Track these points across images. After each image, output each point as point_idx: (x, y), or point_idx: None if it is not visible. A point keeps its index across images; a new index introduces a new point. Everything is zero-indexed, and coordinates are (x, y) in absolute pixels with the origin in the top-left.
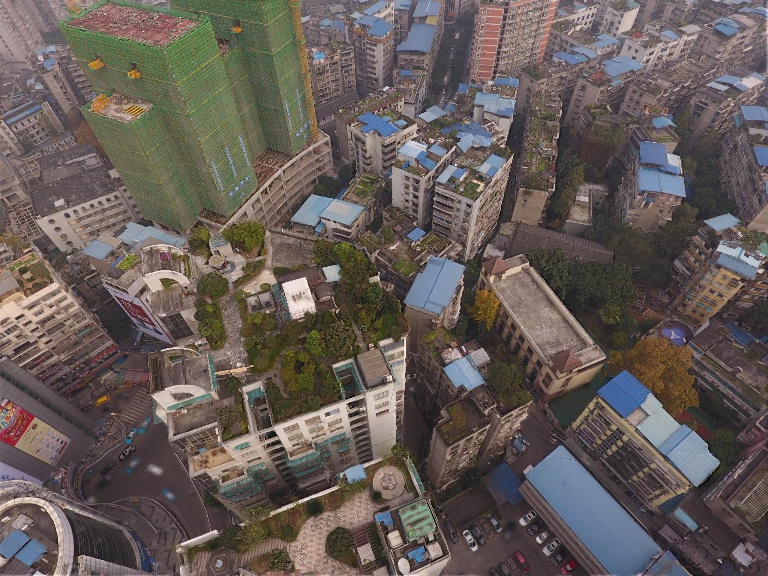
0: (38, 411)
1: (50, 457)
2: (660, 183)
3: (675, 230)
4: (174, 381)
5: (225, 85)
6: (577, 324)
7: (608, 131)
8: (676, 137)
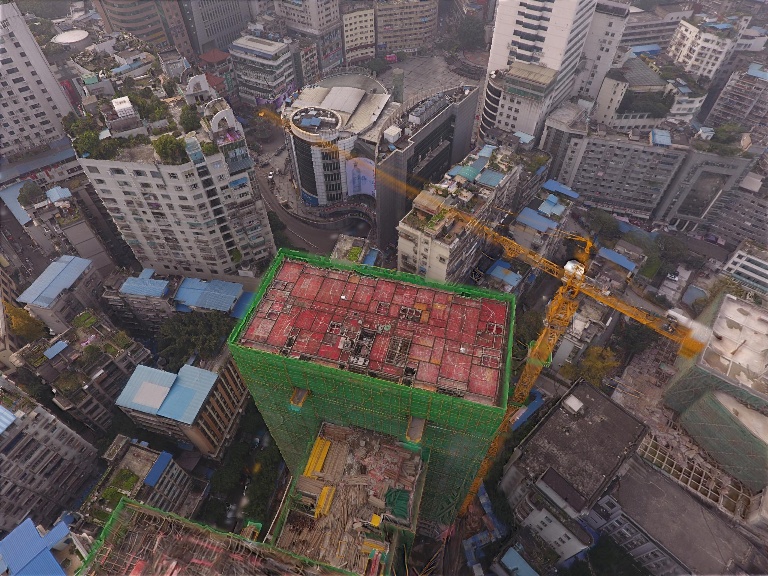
0: None
1: None
2: None
3: None
4: None
5: None
6: None
7: None
8: None
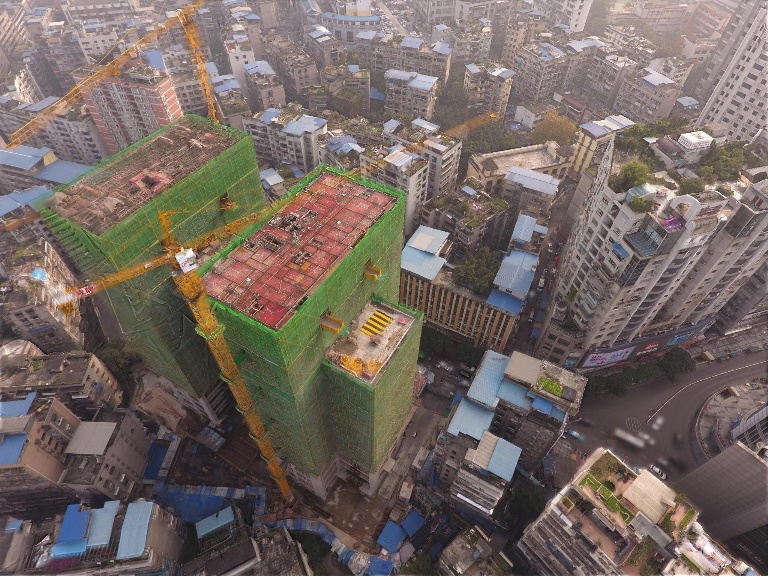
0: None
1: None
2: (426, 81)
3: (460, 92)
4: None
5: None
6: (529, 147)
7: (345, 93)
8: (365, 70)
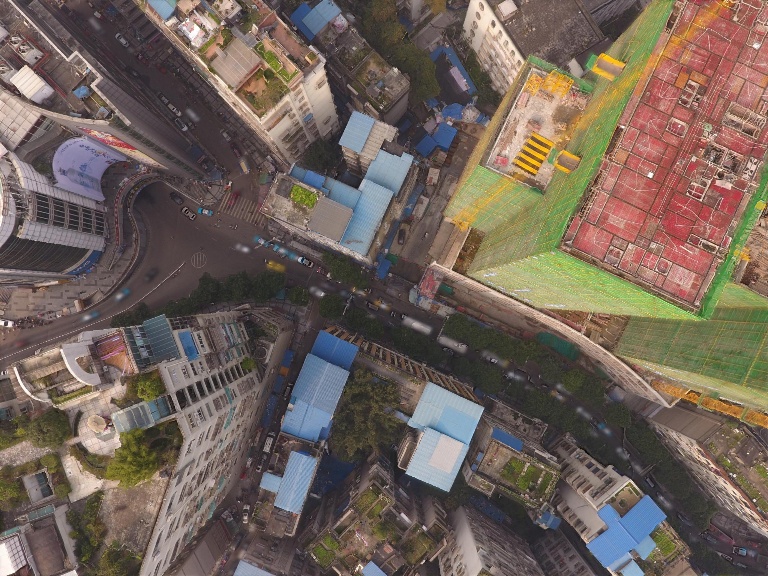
0: (144, 150)
1: (142, 161)
2: None
3: None
4: None
5: None
6: None
7: None
8: None
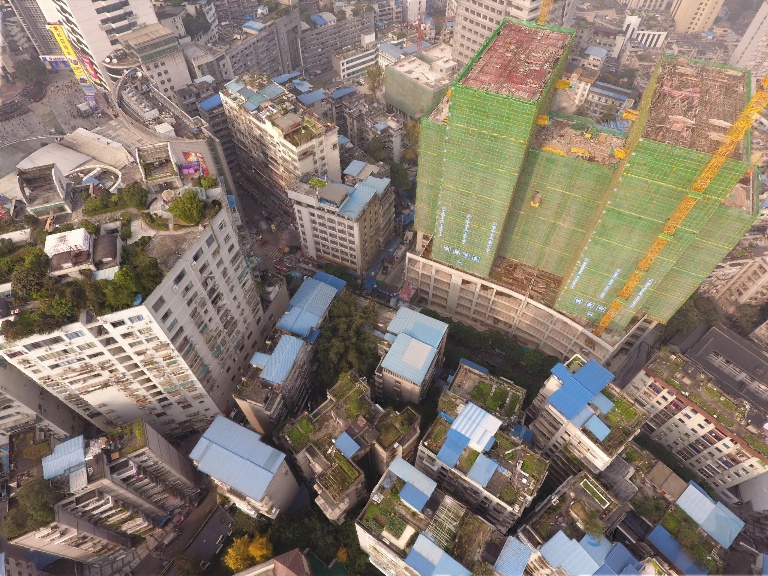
0: None
1: None
2: None
3: None
4: (49, 188)
5: (511, 172)
6: None
7: None
8: None
